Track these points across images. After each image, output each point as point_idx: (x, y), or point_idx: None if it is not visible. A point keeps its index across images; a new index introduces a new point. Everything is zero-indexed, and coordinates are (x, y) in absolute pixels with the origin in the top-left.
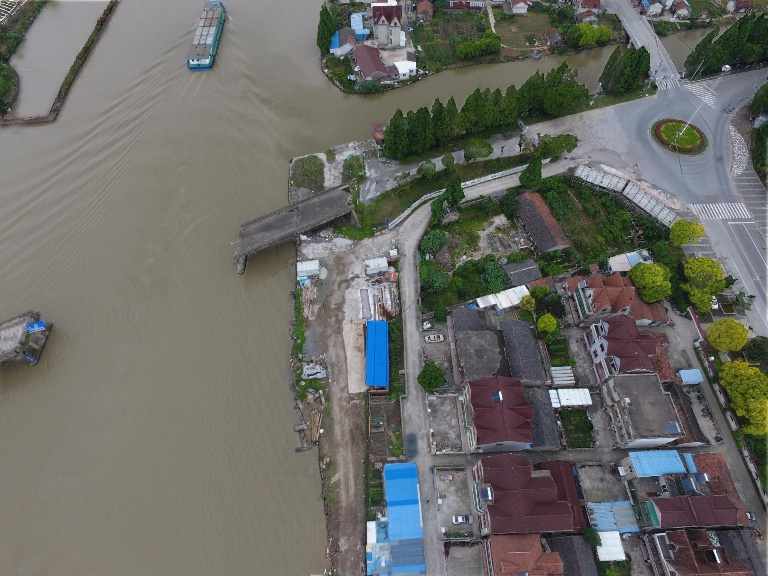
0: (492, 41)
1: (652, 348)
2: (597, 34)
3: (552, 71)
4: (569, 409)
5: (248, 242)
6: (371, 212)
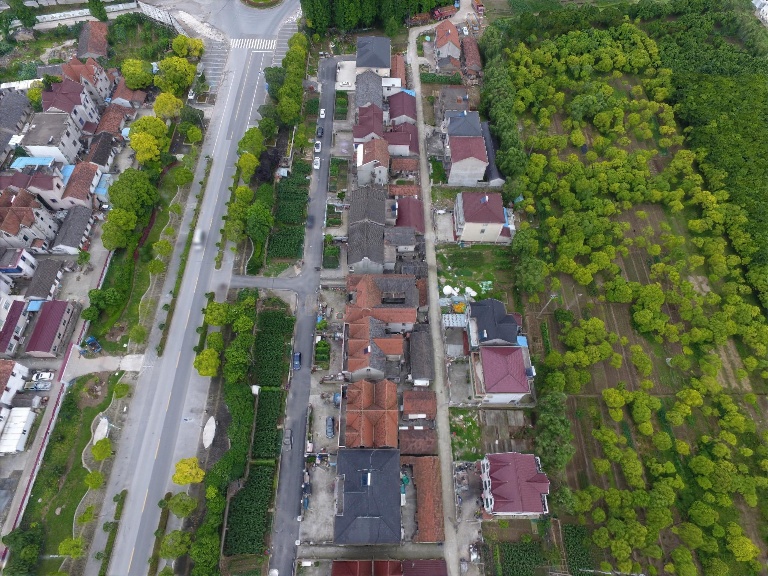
0: None
1: (78, 100)
2: None
3: None
4: None
5: None
6: None
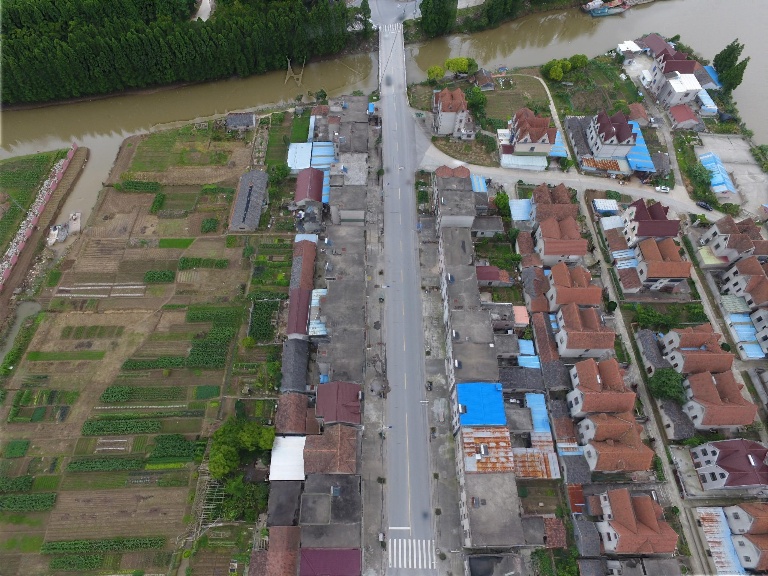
0: (555, 61)
1: None
2: (448, 59)
3: None
4: None
5: None
6: None
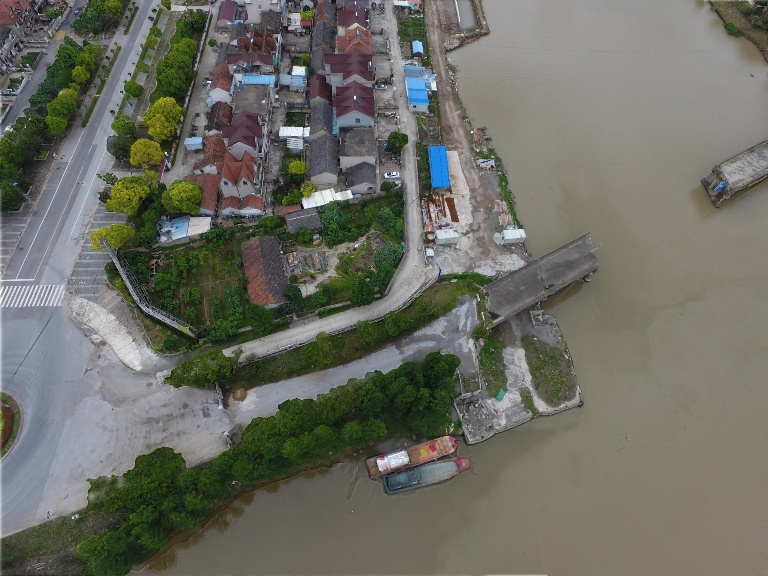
0: None
1: None
2: None
3: (141, 527)
4: None
5: (583, 249)
6: (460, 289)
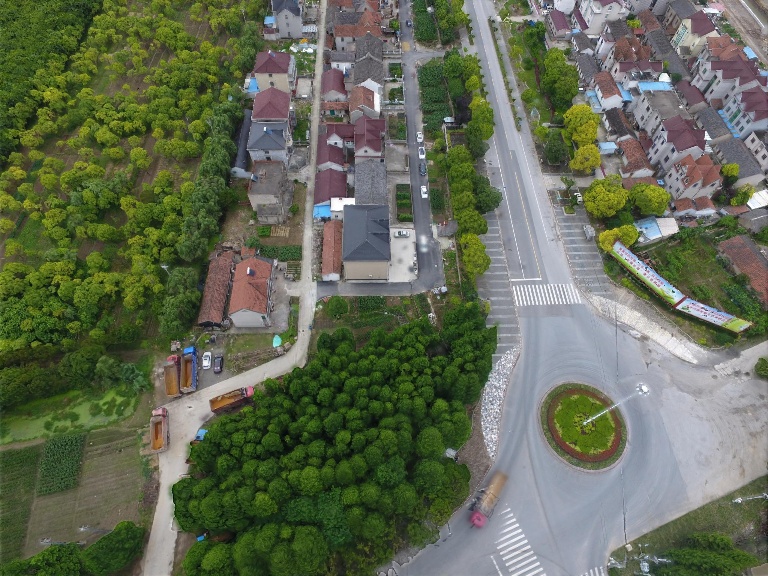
0: None
1: None
2: None
3: None
4: None
5: None
6: None
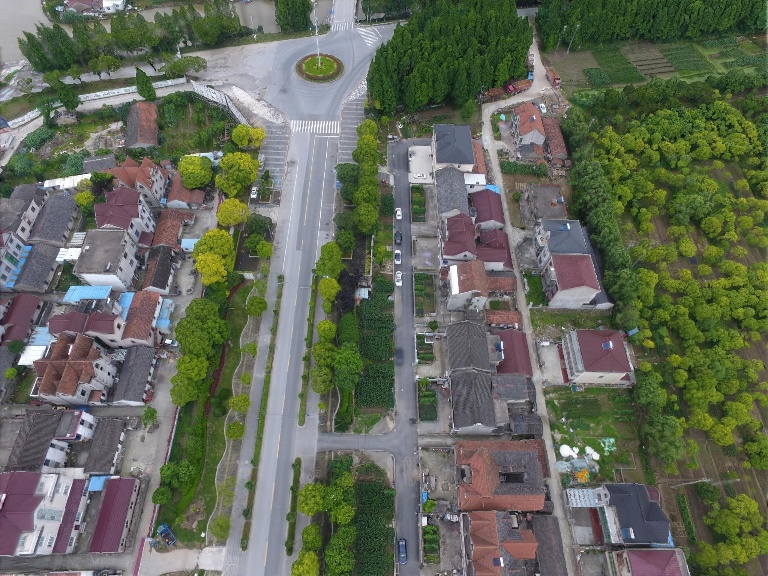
0: None
1: (135, 212)
2: None
3: (205, 3)
4: (72, 263)
5: None
6: None
